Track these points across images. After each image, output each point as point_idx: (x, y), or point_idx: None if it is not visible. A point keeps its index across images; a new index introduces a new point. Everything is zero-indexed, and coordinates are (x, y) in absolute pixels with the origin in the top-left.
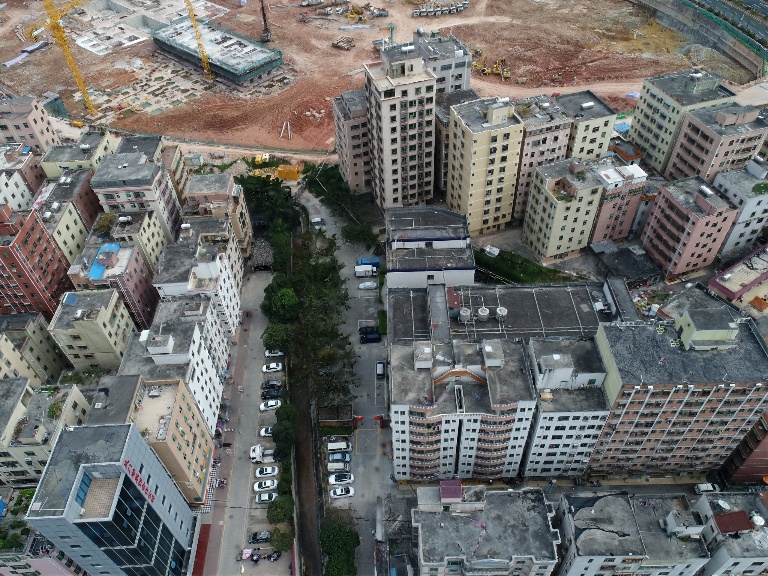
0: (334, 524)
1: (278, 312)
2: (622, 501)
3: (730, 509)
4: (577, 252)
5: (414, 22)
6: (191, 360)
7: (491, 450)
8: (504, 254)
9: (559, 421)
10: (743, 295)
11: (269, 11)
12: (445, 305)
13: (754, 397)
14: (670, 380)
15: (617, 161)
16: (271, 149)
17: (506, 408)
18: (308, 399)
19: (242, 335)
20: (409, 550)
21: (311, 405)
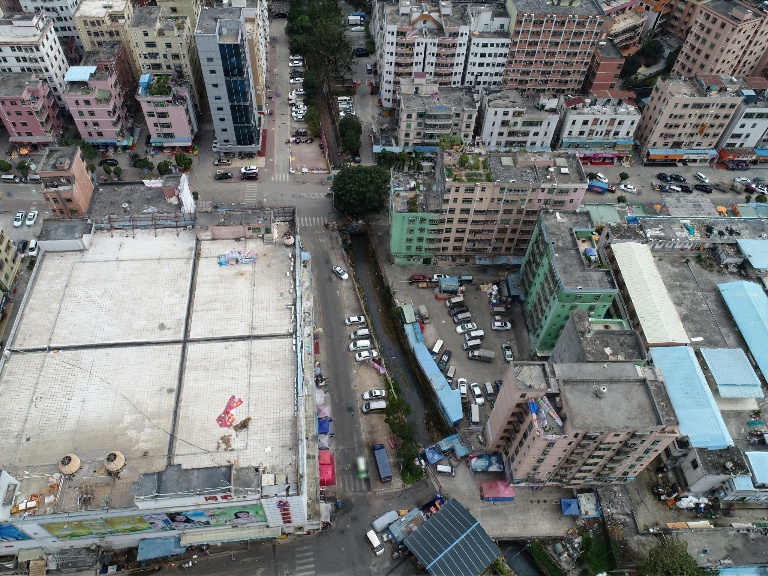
0: (347, 117)
1: (298, 30)
2: (515, 91)
3: None
4: None
5: None
6: (257, 15)
7: (442, 75)
8: None
9: (482, 48)
10: None
11: None
12: (416, 2)
13: (589, 30)
14: None
15: None
16: None
17: (452, 30)
18: (321, 84)
19: (271, 49)
20: (392, 134)
21: (323, 86)
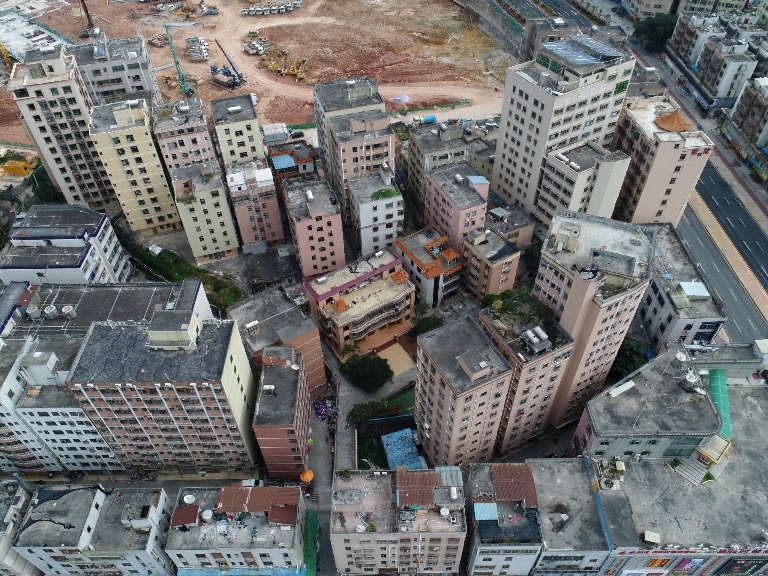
0: None
1: None
2: (89, 494)
3: (197, 503)
4: (235, 253)
5: (240, 21)
6: None
7: (4, 444)
8: (161, 253)
9: (42, 417)
10: (334, 298)
11: (106, 6)
12: (13, 302)
13: (206, 396)
14: (118, 378)
15: (264, 164)
16: (13, 145)
17: None
18: None
19: None
20: None
21: None
